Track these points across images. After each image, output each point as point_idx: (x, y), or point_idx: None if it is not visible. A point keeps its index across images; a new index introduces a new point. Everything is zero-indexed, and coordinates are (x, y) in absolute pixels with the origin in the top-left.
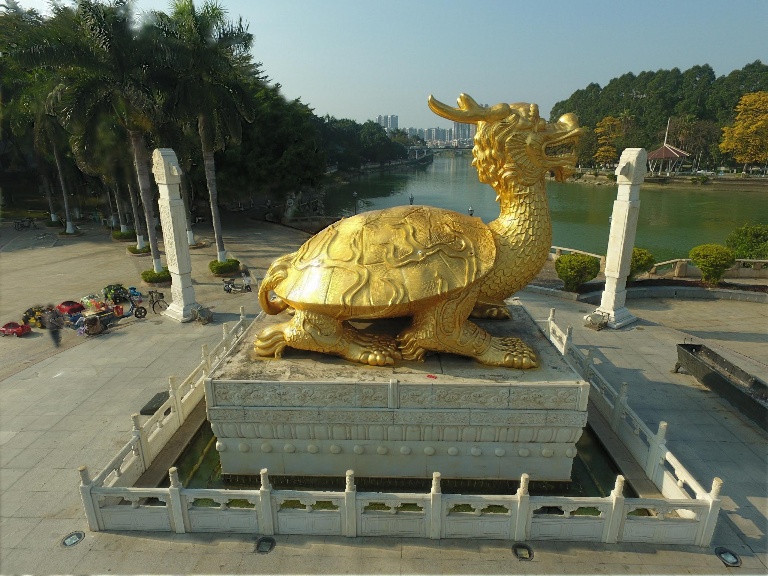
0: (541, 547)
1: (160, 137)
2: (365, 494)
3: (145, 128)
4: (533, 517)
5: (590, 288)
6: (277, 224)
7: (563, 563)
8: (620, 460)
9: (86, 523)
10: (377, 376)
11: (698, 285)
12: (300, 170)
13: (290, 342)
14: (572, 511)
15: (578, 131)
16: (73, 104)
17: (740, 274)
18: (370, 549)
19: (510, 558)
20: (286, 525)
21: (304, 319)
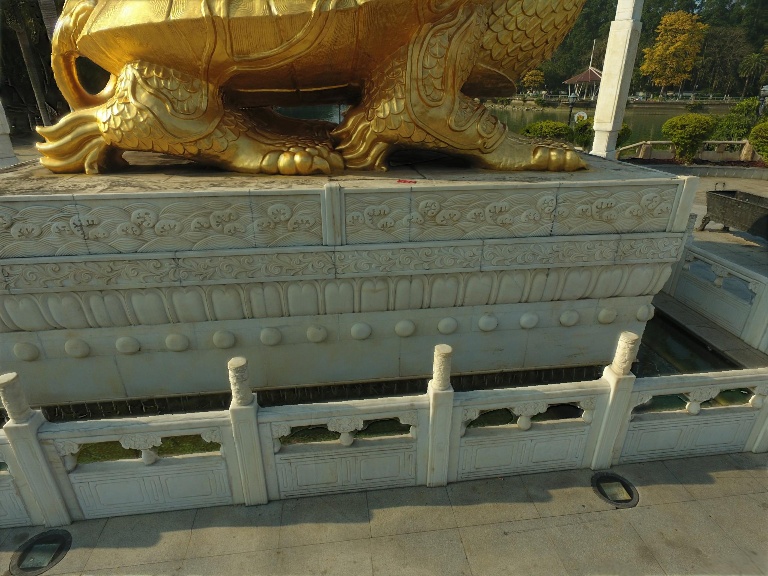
0: (644, 475)
1: None
2: (279, 410)
3: None
4: (631, 420)
5: None
6: None
7: (699, 501)
8: (696, 326)
9: None
10: (296, 183)
11: (672, 162)
12: None
13: (109, 132)
14: (647, 408)
15: None
16: None
17: (703, 158)
18: (299, 526)
19: (596, 505)
20: (98, 499)
21: (133, 77)
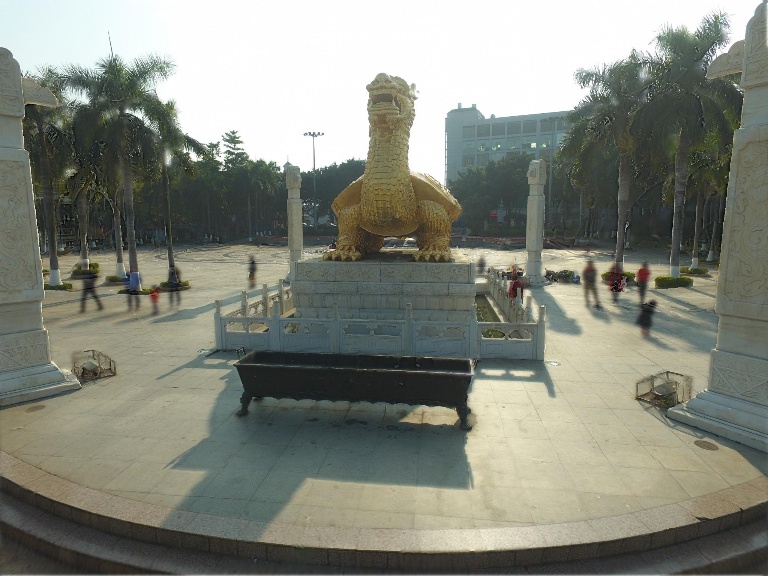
0: None
1: (636, 155)
2: None
3: None
4: None
5: None
6: None
7: None
8: None
9: None
10: None
11: None
12: None
13: None
14: None
15: None
16: (567, 140)
17: None
18: None
19: None
20: None
21: None
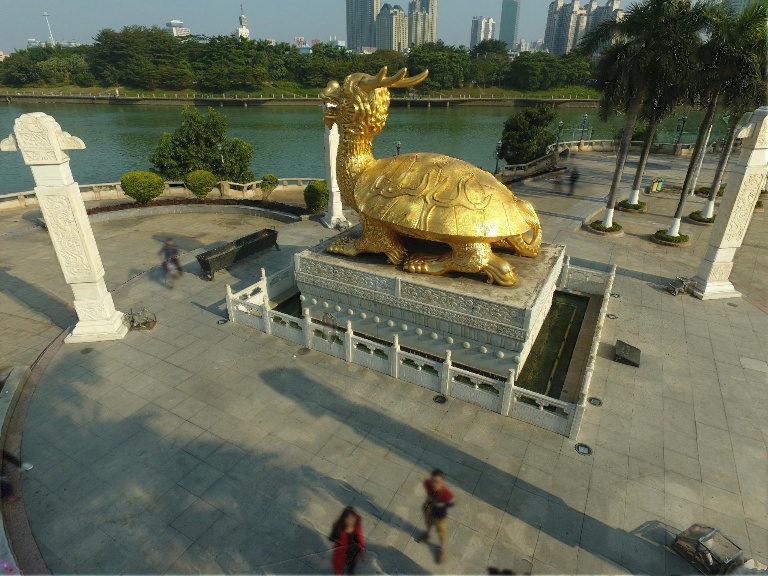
0: None
1: None
2: None
3: None
4: None
5: None
6: None
7: None
8: None
9: (614, 299)
10: None
11: None
12: None
13: None
14: None
15: None
16: None
17: None
18: None
19: None
20: None
21: None
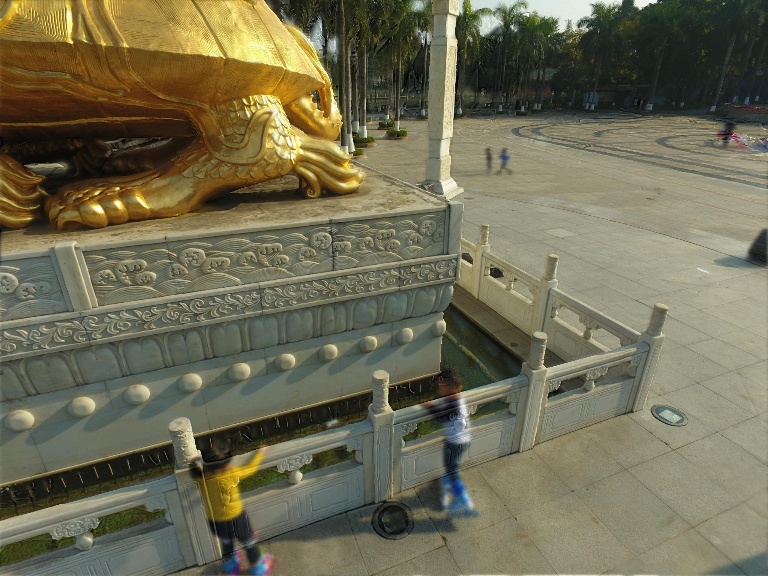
0: None
1: None
2: None
3: None
4: None
5: None
6: None
7: None
8: None
9: None
10: None
11: None
12: None
13: None
14: None
15: None
16: None
17: None
18: None
19: None
20: None
21: None
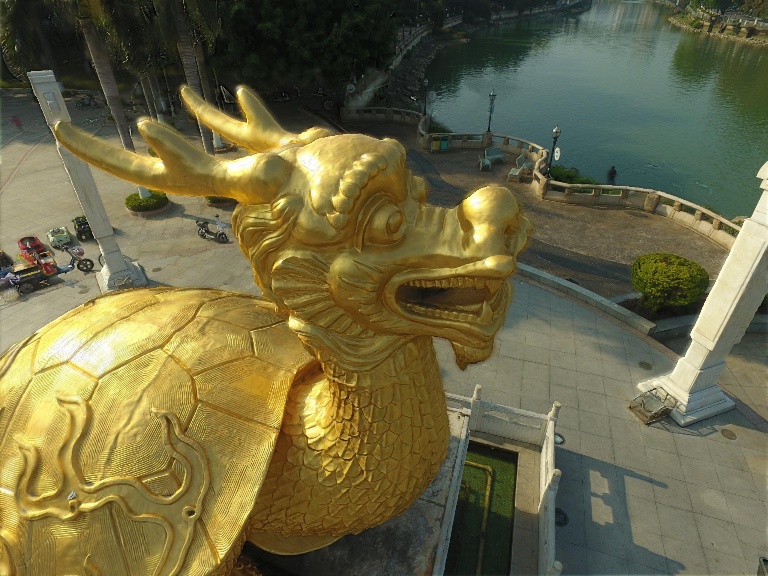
0: None
1: (116, 27)
2: None
3: (97, 14)
4: None
5: (686, 306)
6: (325, 120)
7: None
8: None
9: None
10: None
11: None
12: (359, 48)
13: None
14: None
15: (492, 268)
16: None
17: None
18: None
19: None
20: None
21: None
